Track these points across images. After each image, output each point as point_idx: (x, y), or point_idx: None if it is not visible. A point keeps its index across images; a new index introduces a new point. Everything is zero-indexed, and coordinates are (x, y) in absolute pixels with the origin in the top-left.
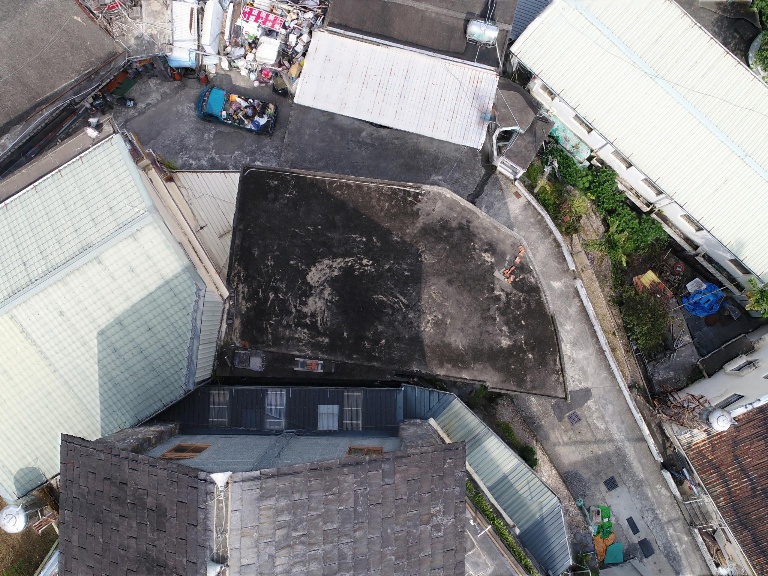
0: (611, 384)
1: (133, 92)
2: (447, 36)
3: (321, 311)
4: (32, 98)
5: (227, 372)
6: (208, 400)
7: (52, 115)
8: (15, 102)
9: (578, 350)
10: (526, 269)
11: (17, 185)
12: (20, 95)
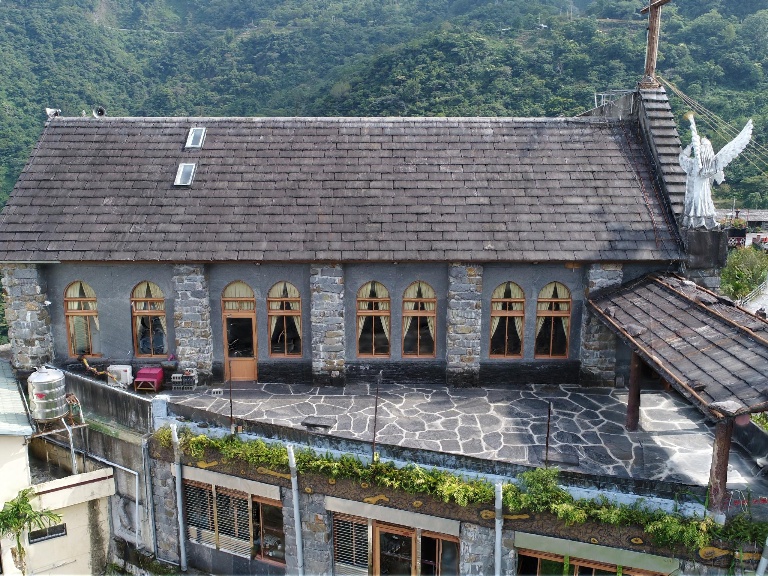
0: None
1: None
2: None
3: None
4: None
5: None
6: None
7: None
8: None
9: None
10: None
11: None
12: None
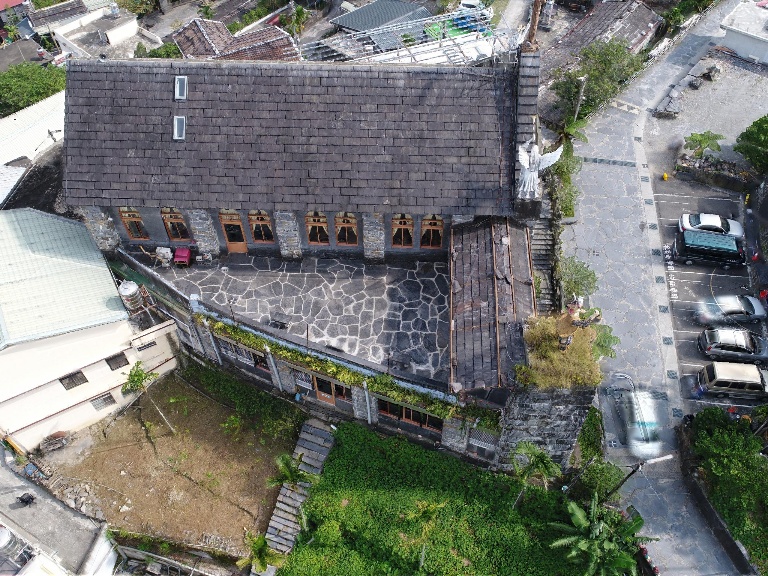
0: None
1: None
2: None
3: None
4: None
5: None
6: None
7: None
8: None
9: None
10: None
11: None
12: None
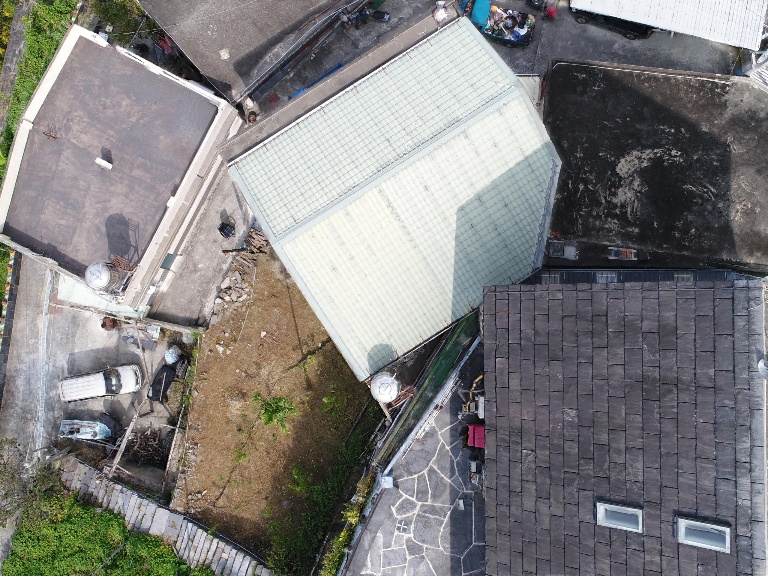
0: None
1: (386, 7)
2: None
3: (631, 202)
4: (305, 7)
5: (544, 260)
6: (540, 283)
7: (324, 24)
8: (289, 11)
9: None
10: None
11: (362, 69)
12: (294, 4)
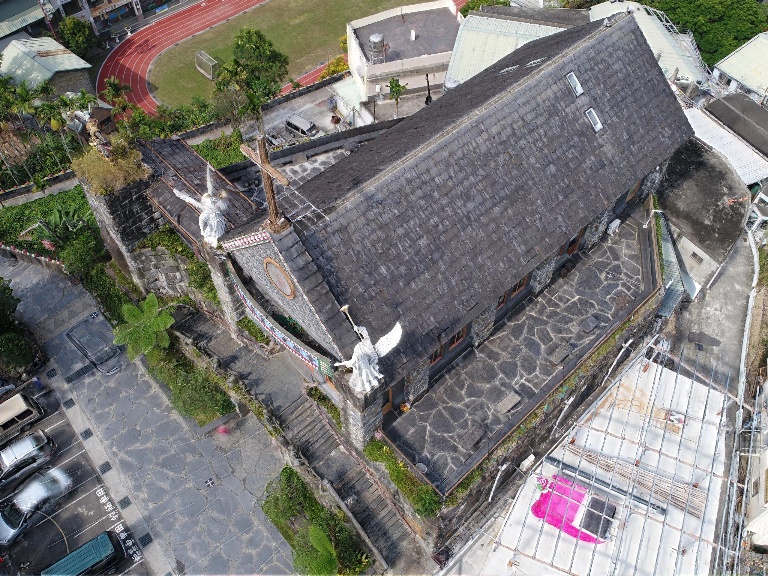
0: (736, 349)
1: None
2: (763, 143)
3: None
4: None
5: None
6: None
7: None
8: None
9: (728, 321)
10: (743, 205)
11: None
12: None
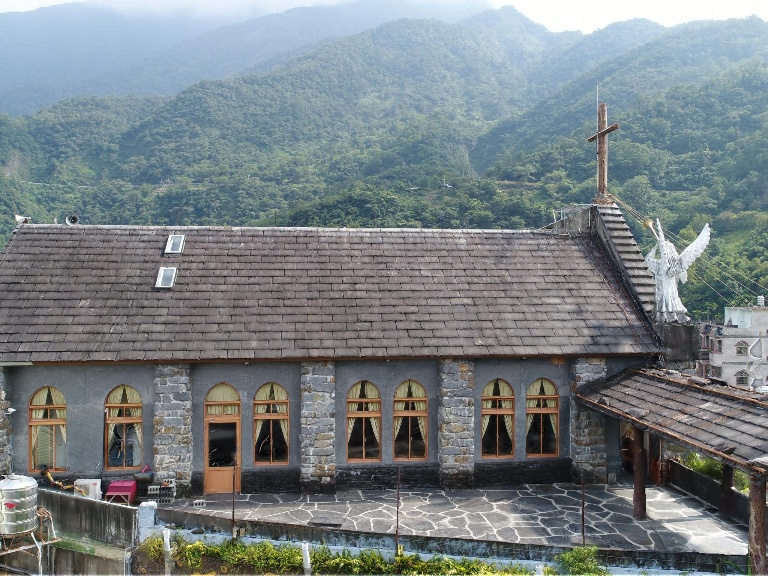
0: None
1: None
2: None
3: None
4: None
5: None
6: None
7: None
8: None
9: None
10: None
11: None
12: None
